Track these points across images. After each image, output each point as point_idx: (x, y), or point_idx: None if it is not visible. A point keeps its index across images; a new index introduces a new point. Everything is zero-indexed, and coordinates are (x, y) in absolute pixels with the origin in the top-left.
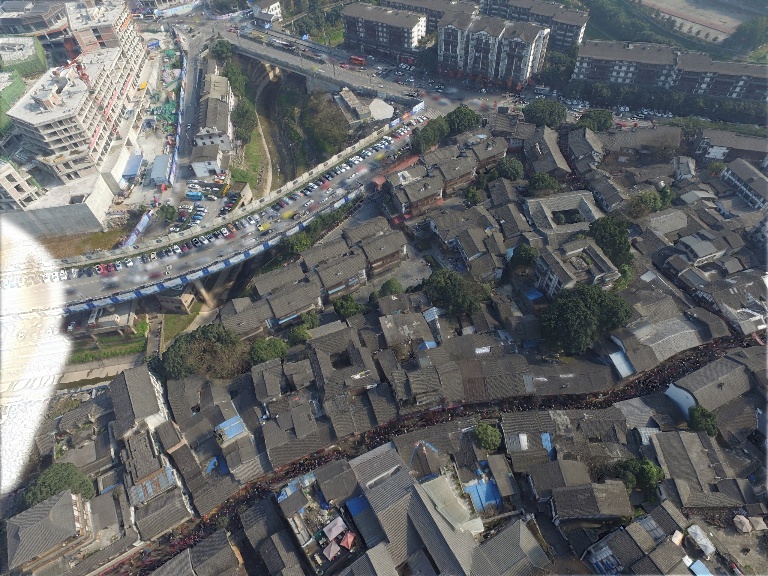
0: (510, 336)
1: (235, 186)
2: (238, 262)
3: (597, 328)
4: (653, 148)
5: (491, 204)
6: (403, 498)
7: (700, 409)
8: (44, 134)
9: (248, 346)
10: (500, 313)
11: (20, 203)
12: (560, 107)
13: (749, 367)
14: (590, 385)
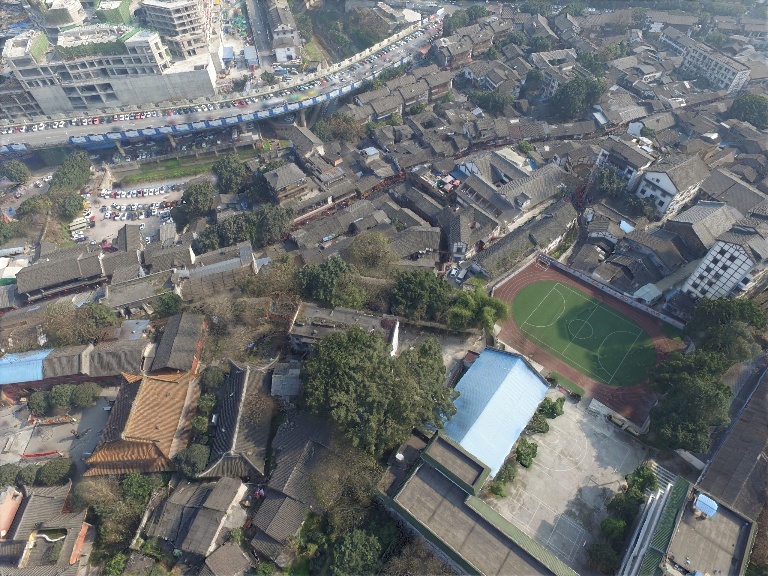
0: (530, 116)
1: (311, 64)
2: (334, 97)
3: (585, 100)
4: (613, 24)
5: (506, 59)
6: (487, 156)
7: (646, 127)
8: (174, 17)
9: (363, 125)
10: (522, 107)
11: (160, 68)
12: (547, 3)
13: (674, 112)
14: (583, 129)
